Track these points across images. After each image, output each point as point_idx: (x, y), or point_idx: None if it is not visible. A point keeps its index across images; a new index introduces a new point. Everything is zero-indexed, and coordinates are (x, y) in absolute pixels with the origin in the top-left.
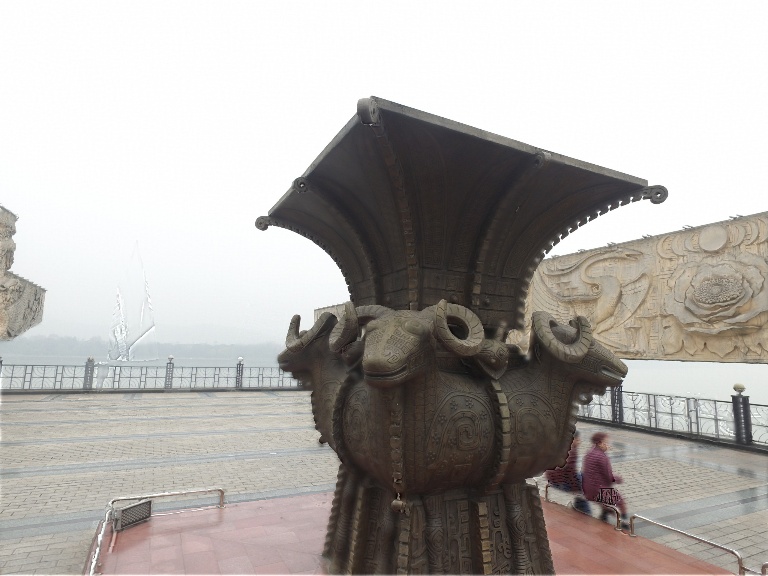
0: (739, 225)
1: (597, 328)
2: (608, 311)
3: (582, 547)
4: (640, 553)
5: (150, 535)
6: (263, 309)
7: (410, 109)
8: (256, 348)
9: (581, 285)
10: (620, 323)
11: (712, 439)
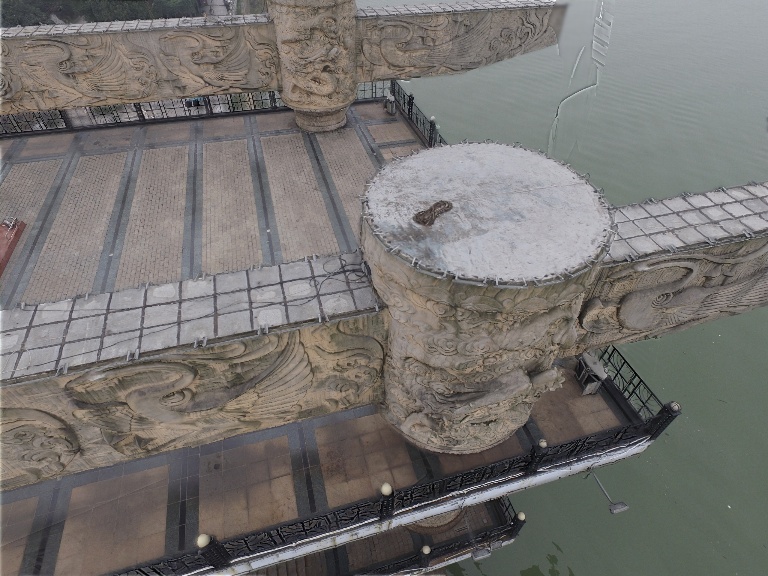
0: None
1: None
2: None
3: None
4: None
5: None
6: (744, 110)
7: None
8: (685, 178)
9: None
10: None
11: None
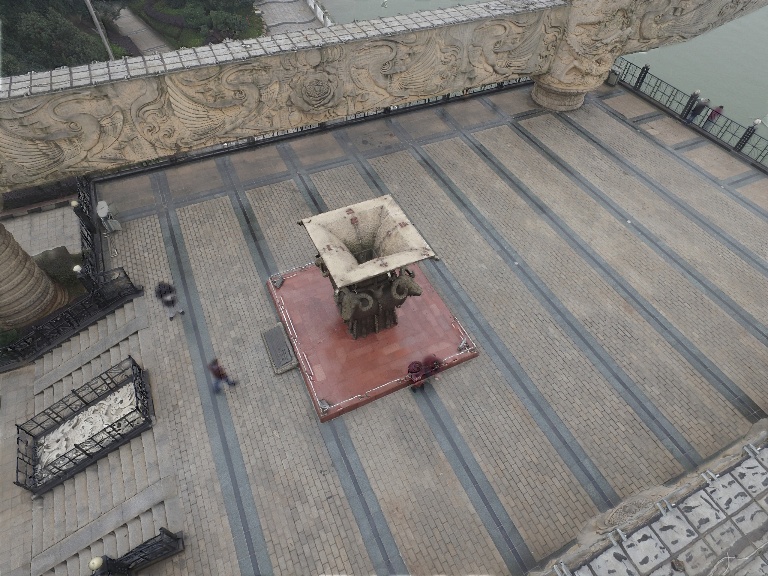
0: None
1: None
2: None
3: (387, 359)
4: (384, 376)
5: None
6: None
7: None
8: None
9: None
10: None
11: None
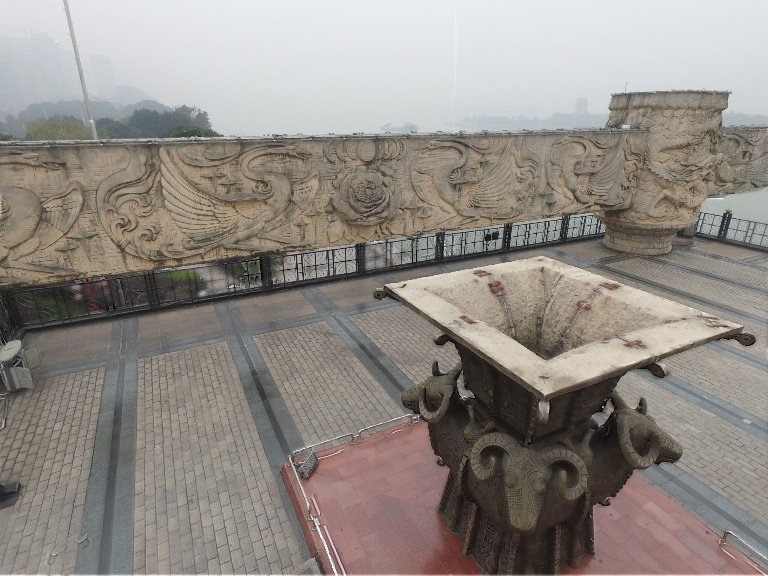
0: None
1: None
2: None
3: None
4: None
5: None
6: None
7: (393, 293)
8: None
9: None
10: None
11: None
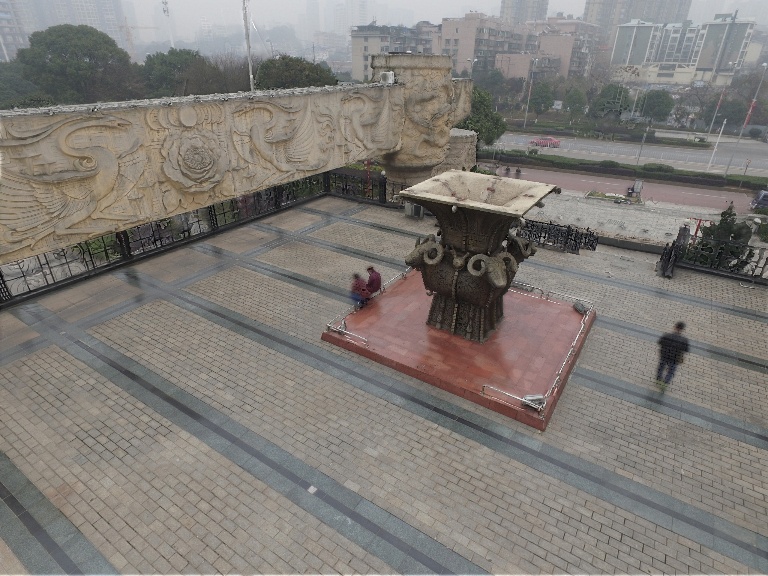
0: (201, 108)
1: (99, 206)
2: (112, 186)
3: None
4: (401, 291)
5: (529, 391)
6: None
7: None
8: None
9: (61, 158)
10: (124, 196)
11: (107, 266)
